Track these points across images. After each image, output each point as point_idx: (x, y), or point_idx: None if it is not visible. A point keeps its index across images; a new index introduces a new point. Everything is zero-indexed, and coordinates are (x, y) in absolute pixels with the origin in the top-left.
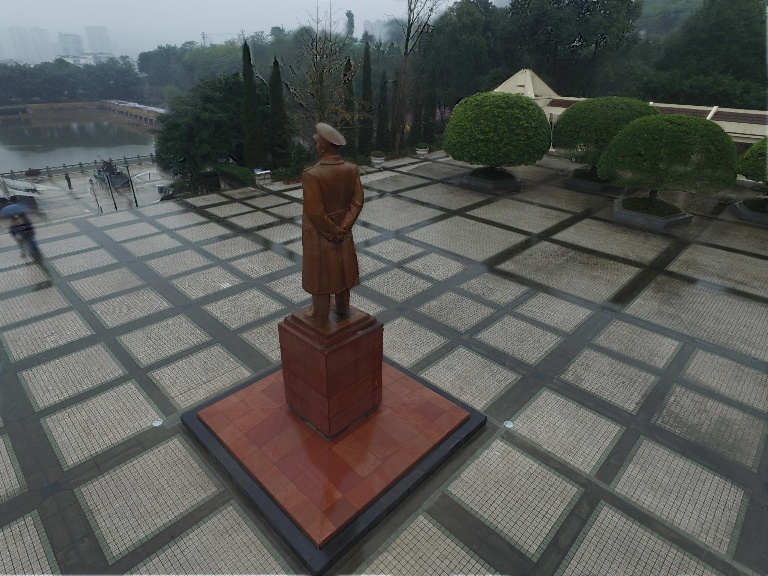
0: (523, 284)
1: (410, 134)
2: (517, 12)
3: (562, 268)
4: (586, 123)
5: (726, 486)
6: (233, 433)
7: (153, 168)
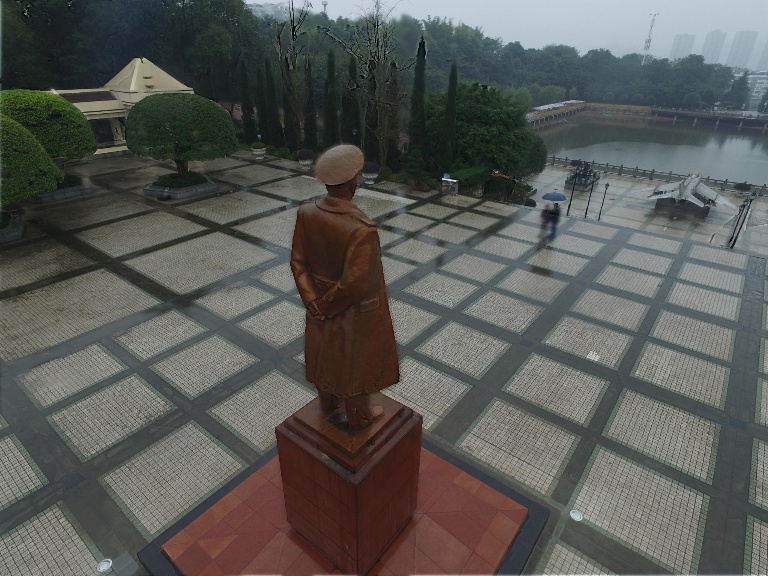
0: None
1: None
2: None
3: None
4: None
5: None
6: None
7: None
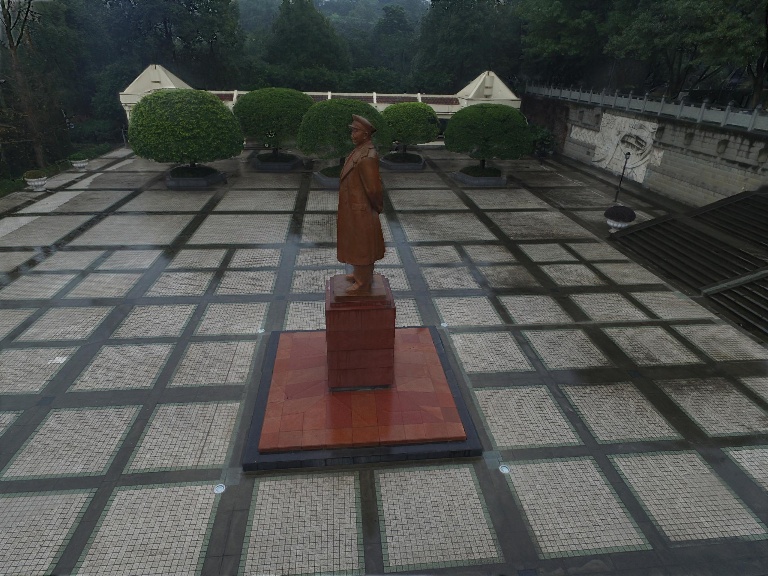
0: (335, 247)
1: (43, 146)
2: (116, 3)
3: None
4: (267, 112)
5: (543, 298)
6: (316, 435)
7: None
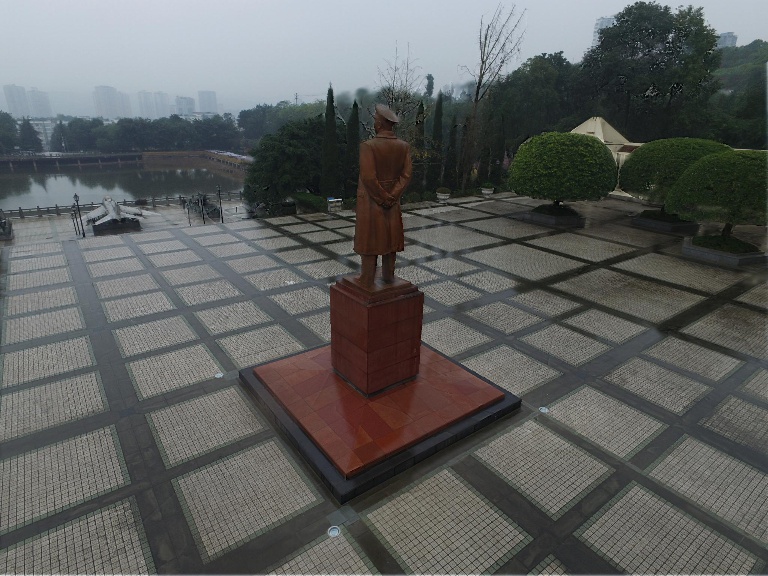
0: (575, 301)
1: (477, 176)
2: (589, 65)
3: (619, 291)
4: (654, 162)
5: None
6: (282, 385)
7: (240, 201)
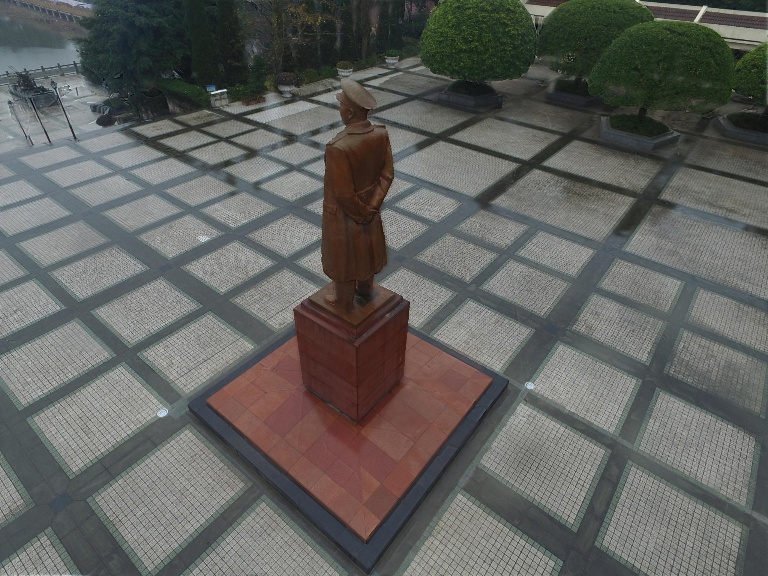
0: (521, 222)
1: (376, 38)
2: None
3: (558, 201)
4: (575, 29)
5: (739, 435)
6: (251, 422)
7: (80, 82)
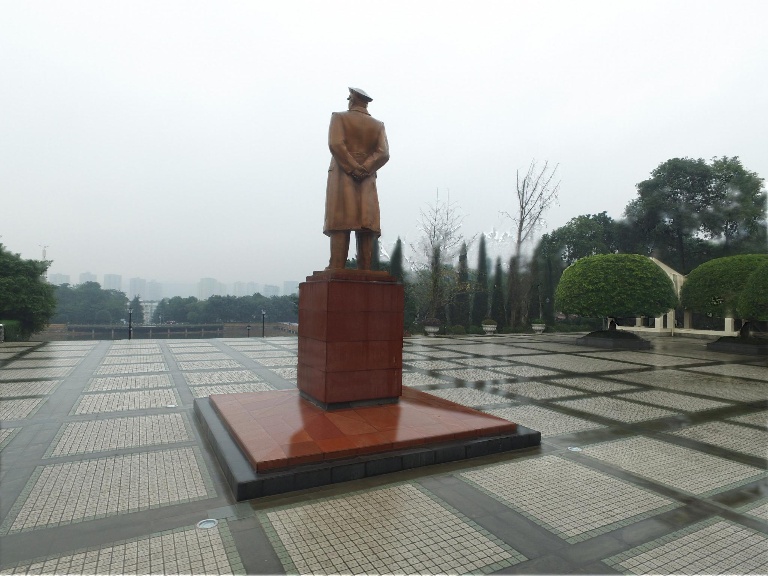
0: (632, 385)
1: (528, 317)
2: (633, 214)
3: (692, 382)
4: (716, 275)
5: None
6: (232, 404)
7: None
